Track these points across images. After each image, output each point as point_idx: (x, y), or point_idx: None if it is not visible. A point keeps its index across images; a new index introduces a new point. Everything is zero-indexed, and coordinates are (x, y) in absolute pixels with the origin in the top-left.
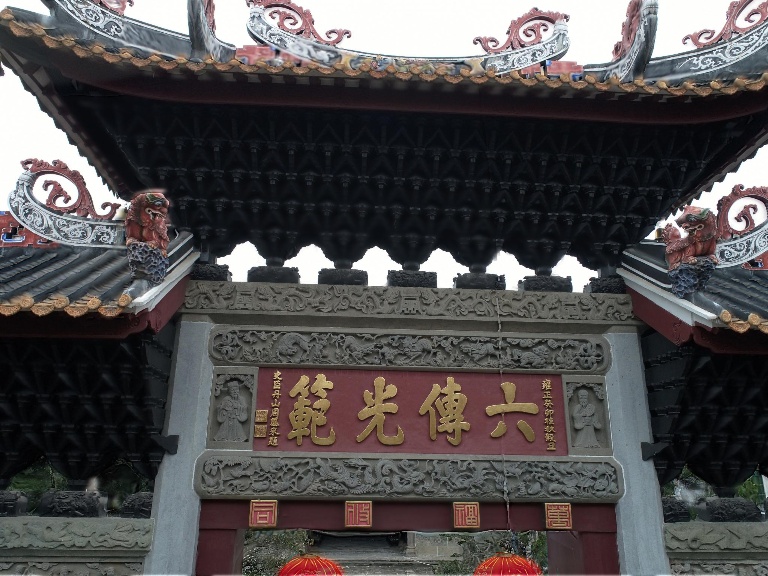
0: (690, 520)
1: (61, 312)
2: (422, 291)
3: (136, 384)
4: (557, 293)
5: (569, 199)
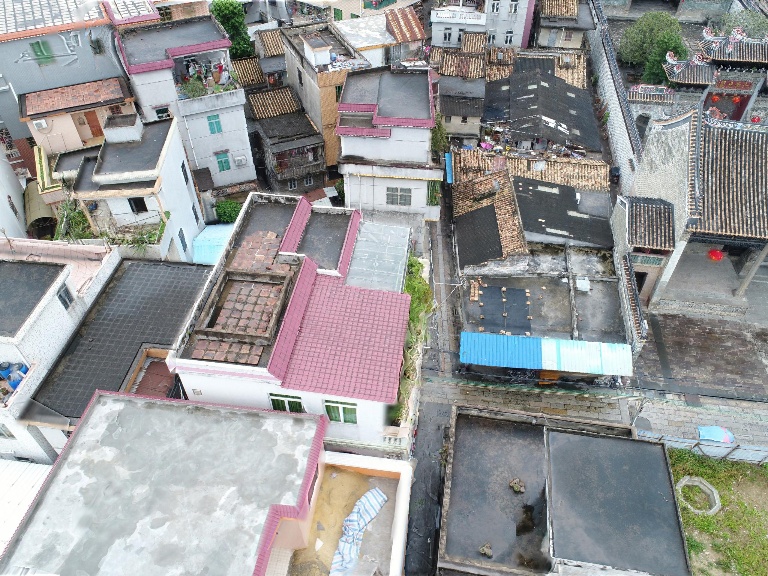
0: (760, 97)
1: None
2: (741, 73)
3: None
4: (758, 74)
5: (765, 65)
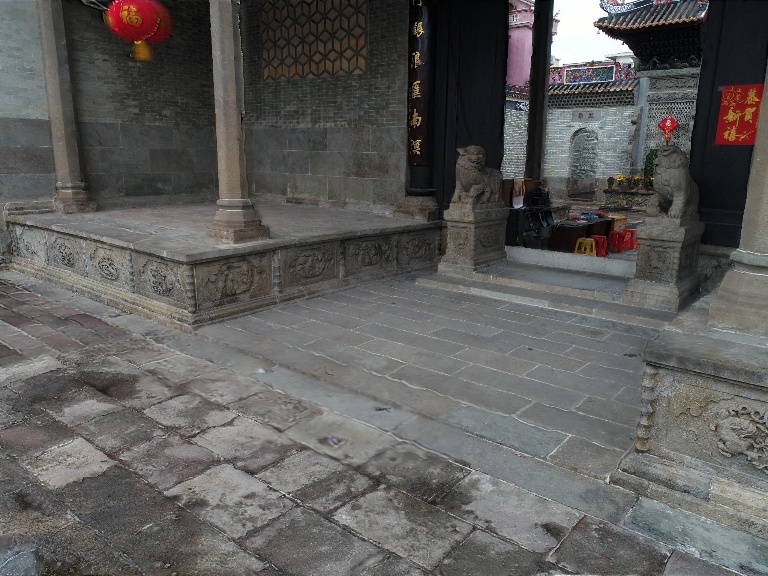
0: None
1: (684, 21)
2: None
3: (698, 35)
4: None
5: None
